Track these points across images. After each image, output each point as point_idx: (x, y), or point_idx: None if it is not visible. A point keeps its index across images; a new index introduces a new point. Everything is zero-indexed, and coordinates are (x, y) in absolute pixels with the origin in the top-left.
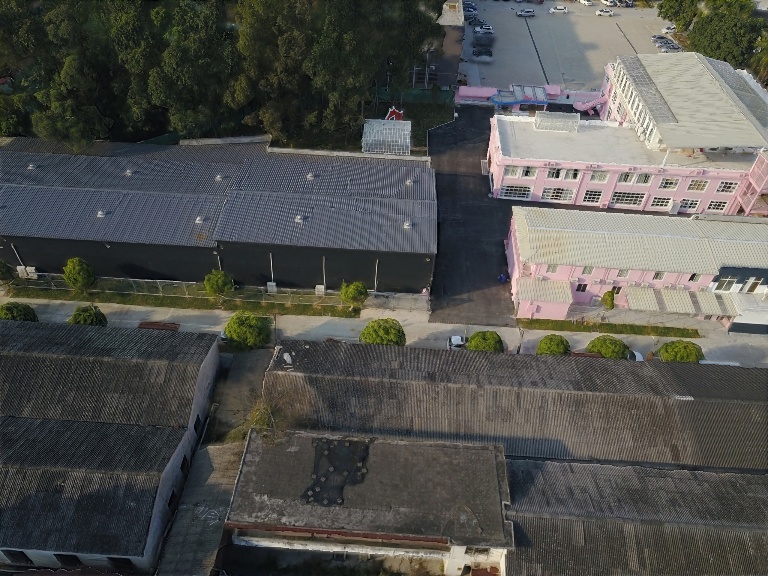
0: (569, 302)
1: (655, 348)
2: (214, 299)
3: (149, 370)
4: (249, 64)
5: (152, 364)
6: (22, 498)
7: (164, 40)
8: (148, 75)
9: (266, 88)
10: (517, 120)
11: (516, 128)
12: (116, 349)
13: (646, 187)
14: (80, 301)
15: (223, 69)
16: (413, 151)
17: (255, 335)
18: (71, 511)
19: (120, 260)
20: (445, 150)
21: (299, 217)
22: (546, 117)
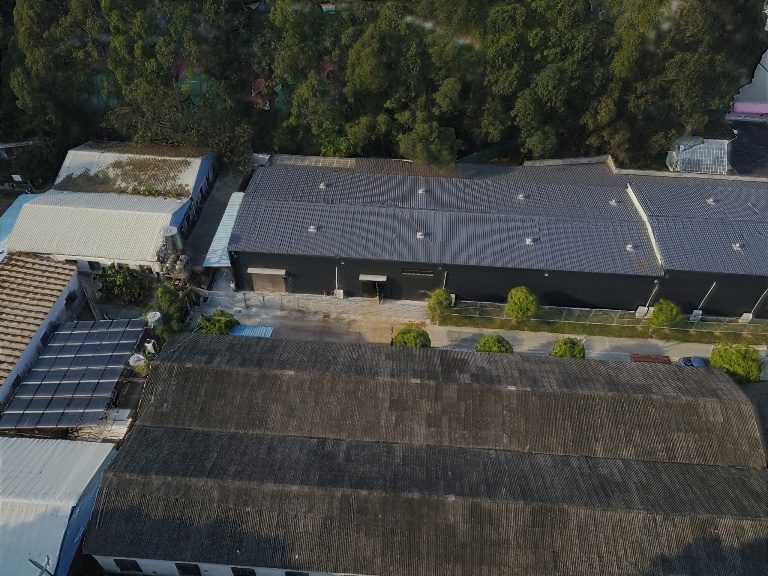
0: None
1: None
2: (642, 327)
3: (703, 408)
4: (615, 86)
5: (703, 402)
6: (682, 546)
7: (532, 62)
8: (515, 97)
9: (635, 110)
10: None
11: None
12: (650, 385)
13: None
14: (511, 329)
15: (589, 91)
16: None
17: (757, 369)
18: (738, 559)
19: (549, 288)
20: (750, 169)
21: (738, 245)
22: None
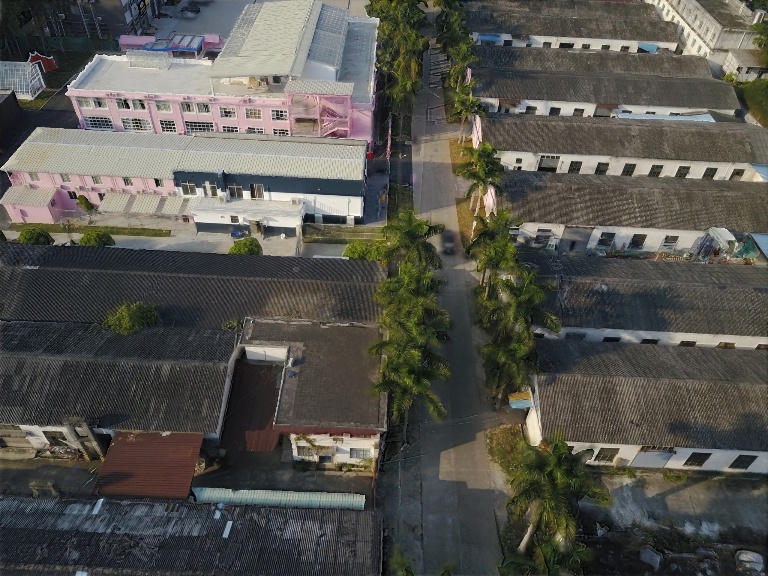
0: (43, 205)
1: (119, 245)
2: None
3: None
4: None
5: None
6: None
7: None
8: None
9: None
10: (119, 59)
11: (112, 66)
12: None
13: (210, 116)
14: None
15: None
16: (44, 92)
17: None
18: None
19: None
20: None
21: None
22: (133, 55)
